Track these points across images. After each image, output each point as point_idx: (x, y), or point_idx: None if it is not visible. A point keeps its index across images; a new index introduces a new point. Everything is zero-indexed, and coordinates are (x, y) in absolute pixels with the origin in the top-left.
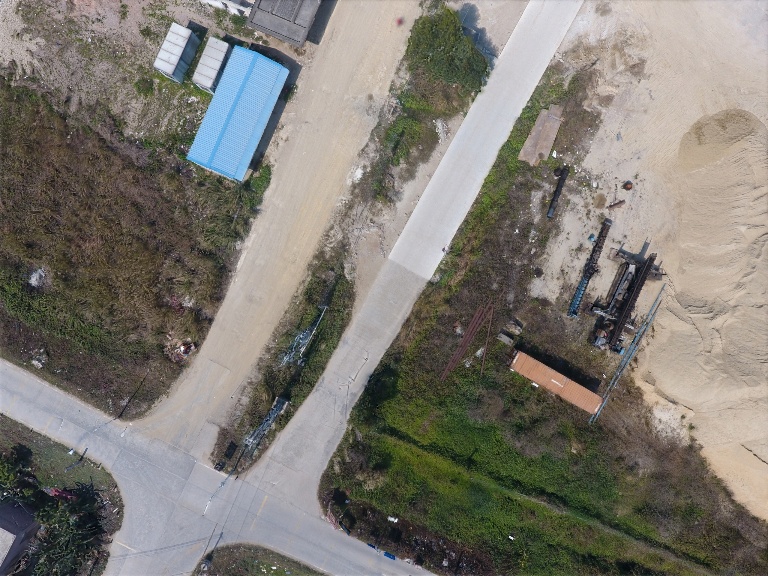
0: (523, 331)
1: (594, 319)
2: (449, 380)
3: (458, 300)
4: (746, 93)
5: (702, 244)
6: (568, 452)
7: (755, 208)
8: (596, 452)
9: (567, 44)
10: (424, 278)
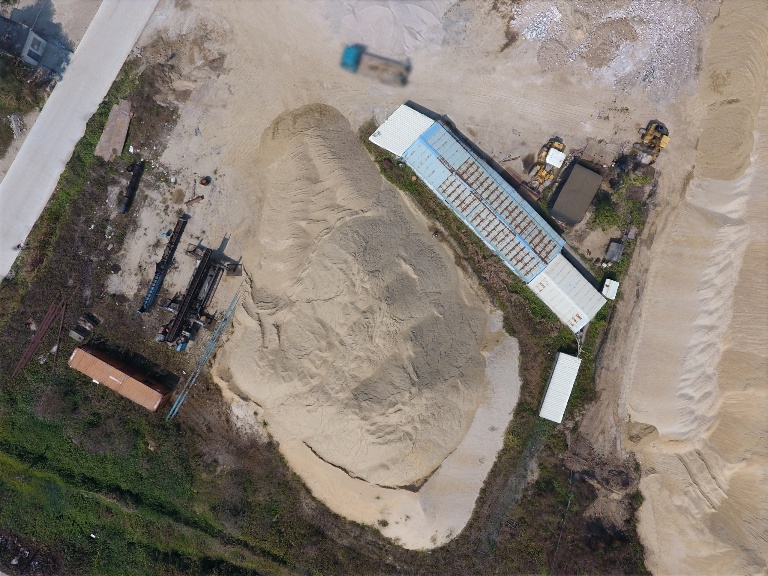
0: (99, 328)
1: (173, 315)
2: (20, 377)
3: (29, 297)
4: (329, 88)
5: (272, 239)
6: (143, 449)
7: (316, 203)
8: (169, 449)
9: (146, 39)
10: (0, 275)
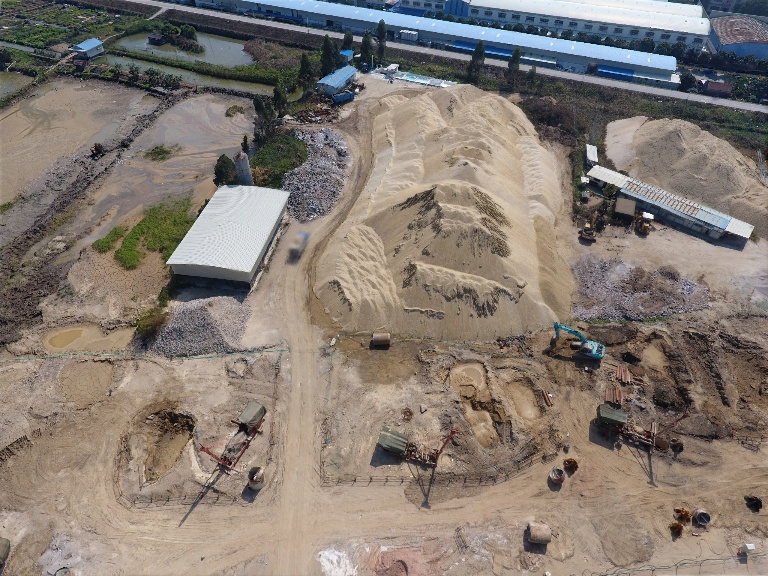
0: None
1: None
2: None
3: None
4: None
5: None
6: None
7: (761, 200)
8: None
9: None
10: None
